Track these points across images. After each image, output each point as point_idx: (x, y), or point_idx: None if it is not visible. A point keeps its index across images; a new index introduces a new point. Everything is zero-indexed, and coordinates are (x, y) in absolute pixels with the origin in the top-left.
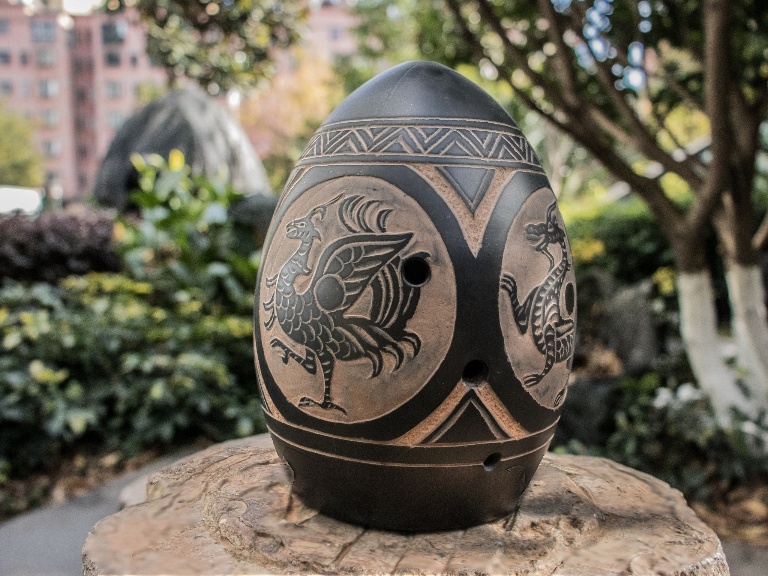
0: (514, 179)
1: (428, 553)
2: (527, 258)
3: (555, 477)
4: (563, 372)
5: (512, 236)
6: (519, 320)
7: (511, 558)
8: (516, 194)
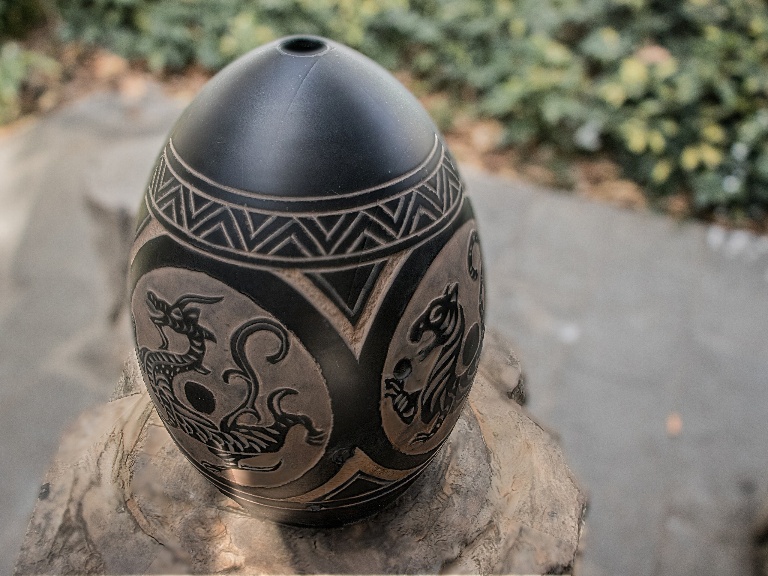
0: (158, 240)
1: (174, 444)
2: (143, 317)
3: (344, 570)
4: (204, 450)
5: (139, 288)
6: (140, 358)
7: (170, 504)
8: (153, 255)
